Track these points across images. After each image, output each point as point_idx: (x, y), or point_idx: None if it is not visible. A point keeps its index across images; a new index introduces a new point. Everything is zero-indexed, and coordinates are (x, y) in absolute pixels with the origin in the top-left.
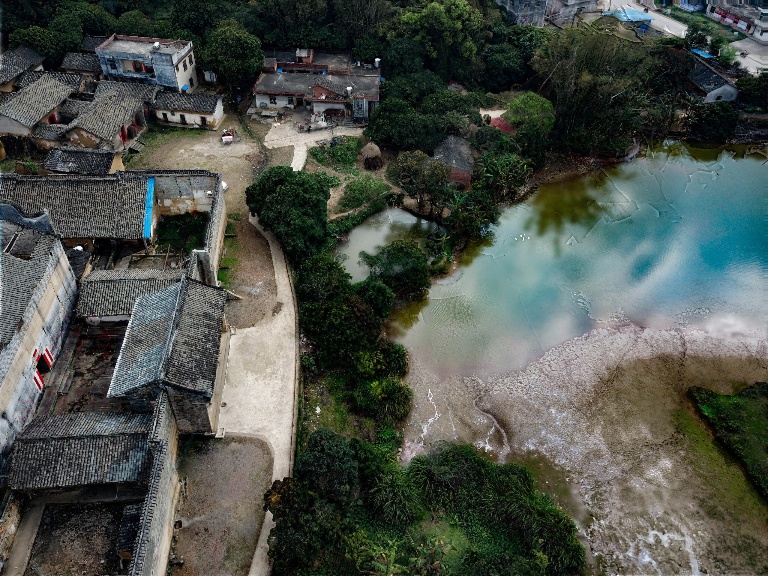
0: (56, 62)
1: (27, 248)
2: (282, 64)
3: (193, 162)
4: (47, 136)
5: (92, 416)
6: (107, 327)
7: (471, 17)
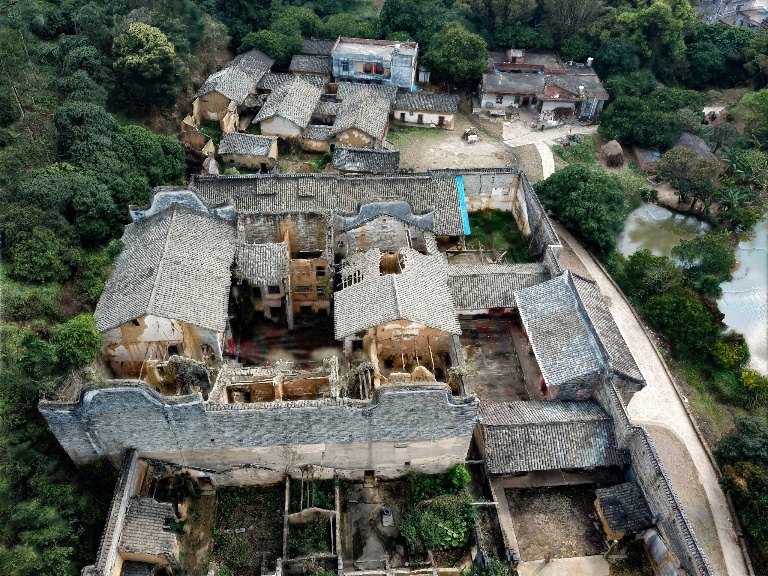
0: (282, 64)
1: (400, 244)
2: (498, 64)
3: (448, 161)
4: (317, 137)
5: (527, 404)
6: (465, 320)
7: (691, 16)
